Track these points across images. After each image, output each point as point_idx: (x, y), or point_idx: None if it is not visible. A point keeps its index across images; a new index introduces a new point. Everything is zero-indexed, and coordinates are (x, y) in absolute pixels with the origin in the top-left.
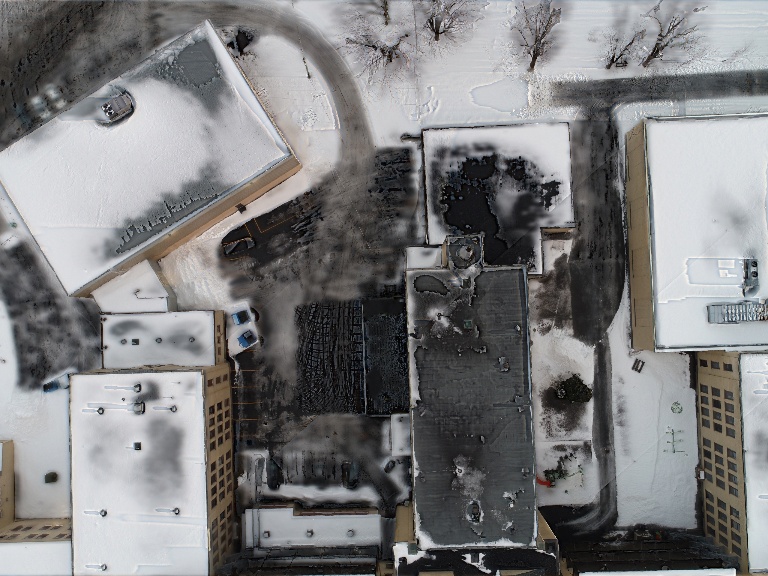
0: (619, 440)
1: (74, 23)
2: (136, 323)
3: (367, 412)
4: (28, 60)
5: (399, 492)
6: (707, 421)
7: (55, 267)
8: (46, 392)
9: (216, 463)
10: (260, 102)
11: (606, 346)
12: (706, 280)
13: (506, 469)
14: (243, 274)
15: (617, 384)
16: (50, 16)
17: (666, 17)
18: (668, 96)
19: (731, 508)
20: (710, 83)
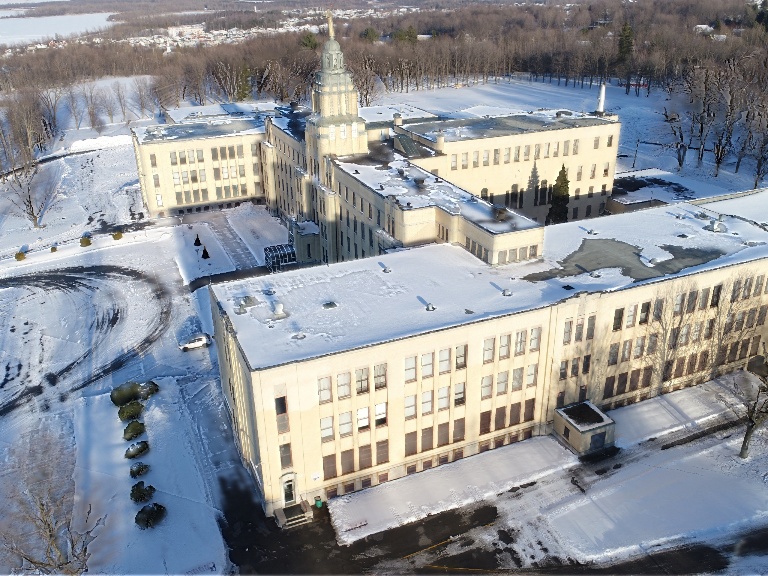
0: None
1: None
2: None
3: None
4: None
5: None
6: None
7: (450, 114)
8: None
9: None
10: None
11: None
12: None
13: None
14: None
15: None
16: None
17: None
18: None
19: None
20: None
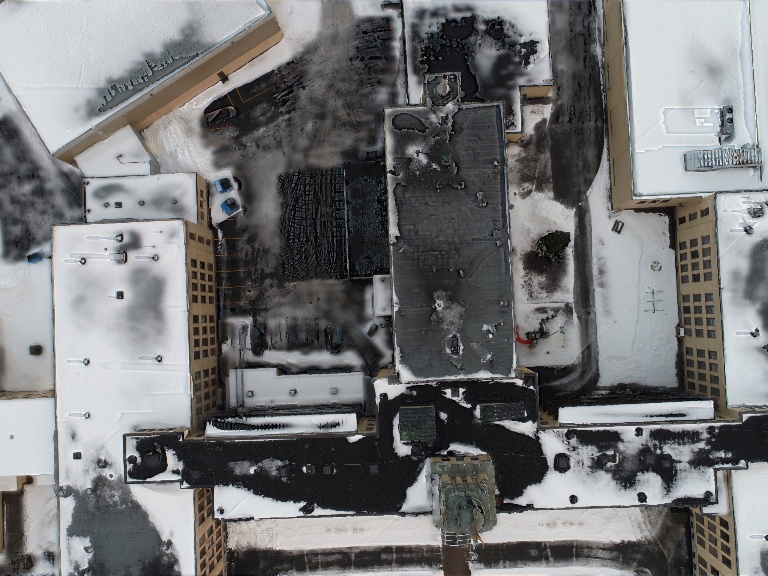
0: (600, 301)
1: None
2: (119, 186)
3: (349, 274)
4: None
5: (382, 356)
6: (686, 276)
7: (37, 127)
8: (30, 263)
9: (199, 318)
10: None
11: (586, 209)
12: (683, 129)
13: (485, 302)
14: (226, 143)
15: (597, 246)
16: None
17: None
18: None
19: (709, 352)
20: None
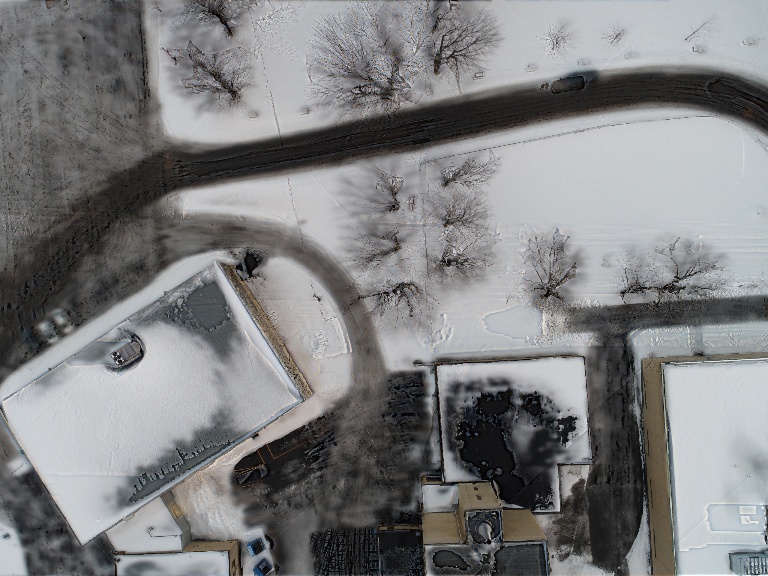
0: None
1: (80, 245)
2: (150, 564)
3: None
4: (34, 282)
5: None
6: None
7: (67, 517)
8: None
9: None
10: (271, 347)
11: (626, 572)
12: (727, 527)
13: None
14: (257, 501)
15: None
16: (55, 237)
17: (681, 242)
18: (684, 321)
19: None
20: (727, 308)
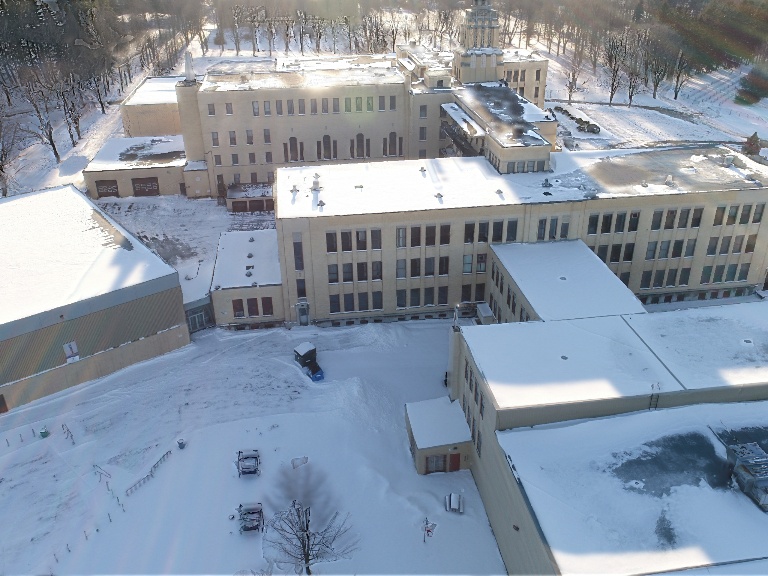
0: None
1: None
2: (227, 269)
3: None
4: None
5: None
6: None
7: (133, 284)
8: None
9: None
10: (6, 197)
11: None
12: None
13: None
14: None
15: None
16: None
17: None
18: None
19: None
20: None
